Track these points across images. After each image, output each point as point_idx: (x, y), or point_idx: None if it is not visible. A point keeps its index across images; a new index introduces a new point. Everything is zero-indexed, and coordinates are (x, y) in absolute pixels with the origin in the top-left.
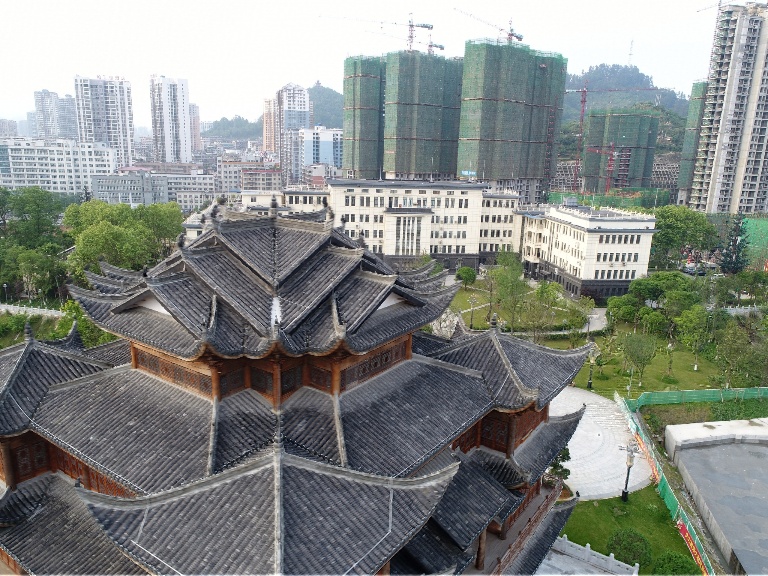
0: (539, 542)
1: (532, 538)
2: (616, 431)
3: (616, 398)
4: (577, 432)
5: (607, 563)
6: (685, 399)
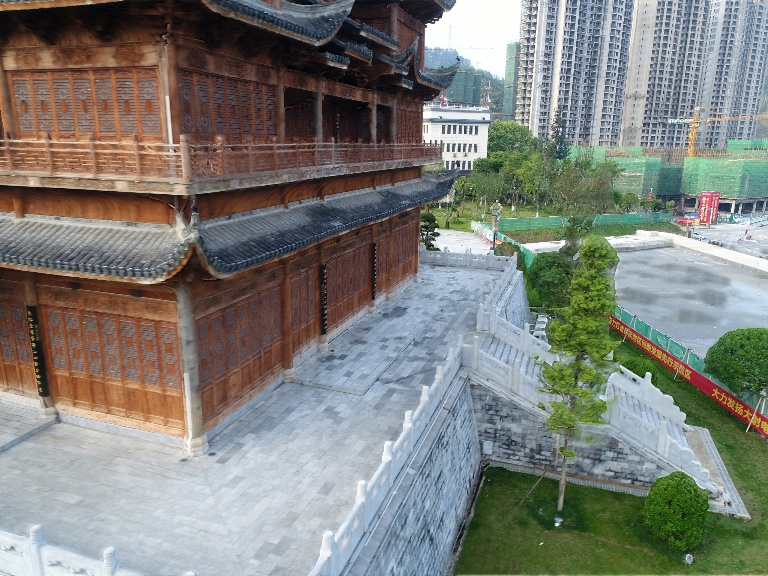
0: (426, 192)
1: (419, 188)
2: (477, 243)
3: (473, 226)
4: (441, 245)
5: (488, 261)
6: (532, 226)
